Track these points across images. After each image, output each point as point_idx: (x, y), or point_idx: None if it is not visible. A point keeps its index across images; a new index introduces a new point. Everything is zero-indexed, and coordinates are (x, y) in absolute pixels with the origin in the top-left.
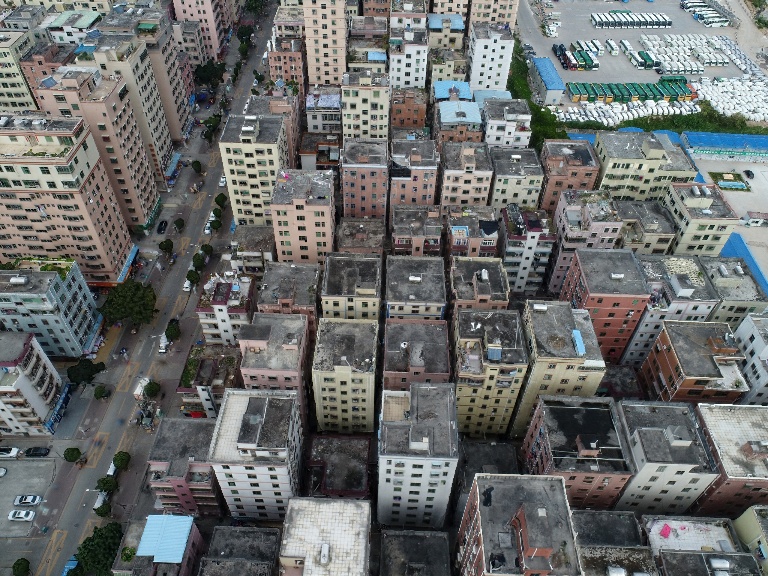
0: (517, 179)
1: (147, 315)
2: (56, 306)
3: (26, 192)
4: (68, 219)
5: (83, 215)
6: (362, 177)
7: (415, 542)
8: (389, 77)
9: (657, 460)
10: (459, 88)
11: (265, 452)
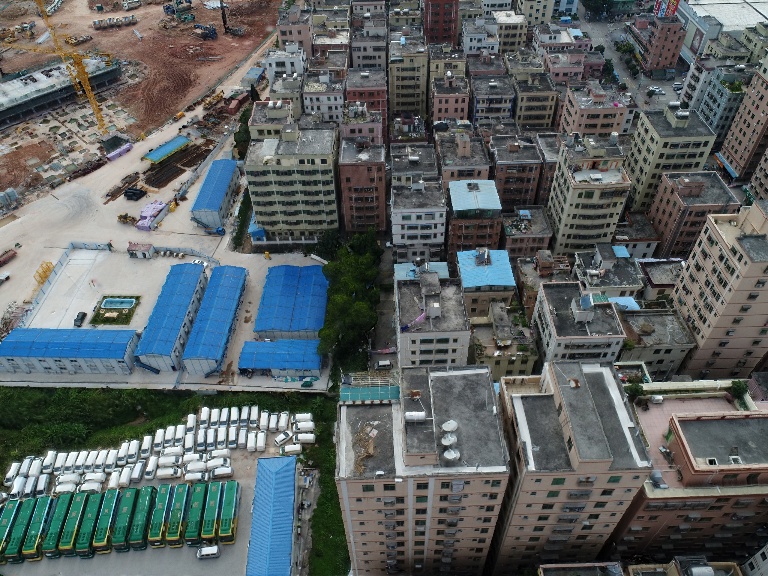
0: None
1: None
2: (711, 80)
3: None
4: None
5: None
6: None
7: None
8: (572, 179)
9: None
10: (477, 269)
11: None
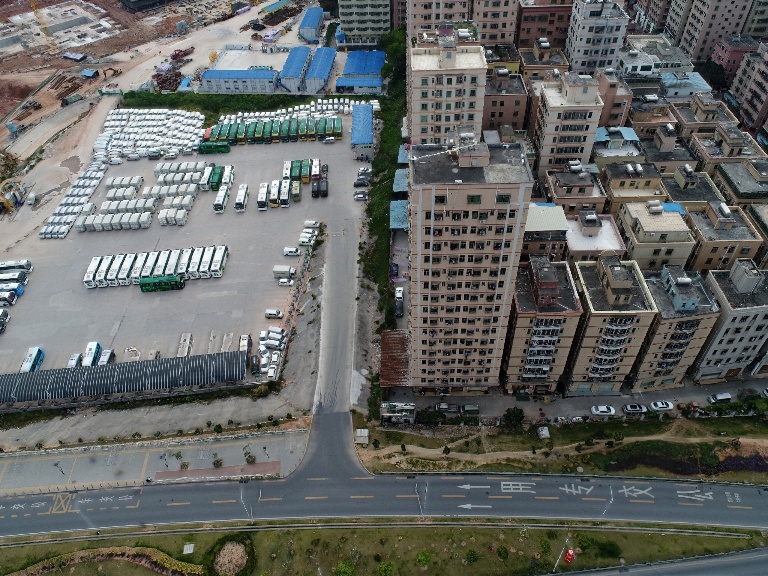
0: None
1: None
2: None
3: None
4: None
5: None
6: None
7: None
8: None
9: None
10: None
11: None
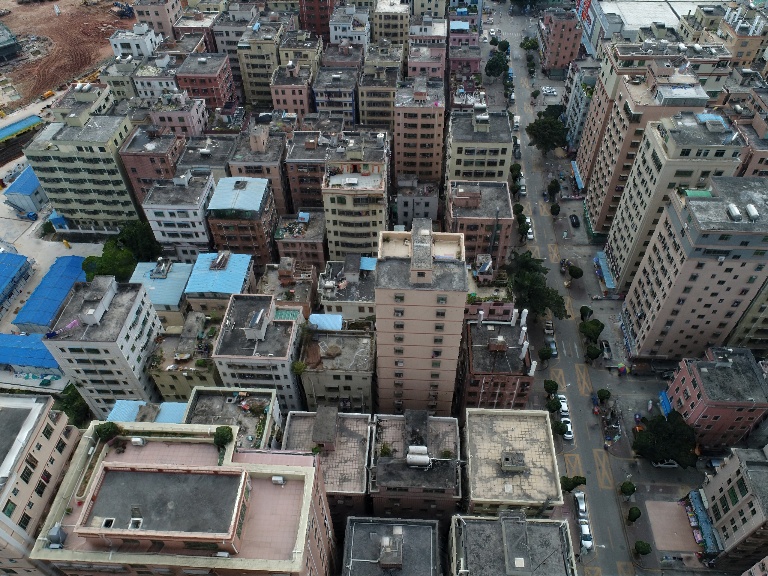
0: None
1: None
2: None
3: None
4: None
5: None
6: None
7: None
8: (323, 182)
9: (250, 4)
10: (207, 274)
11: None
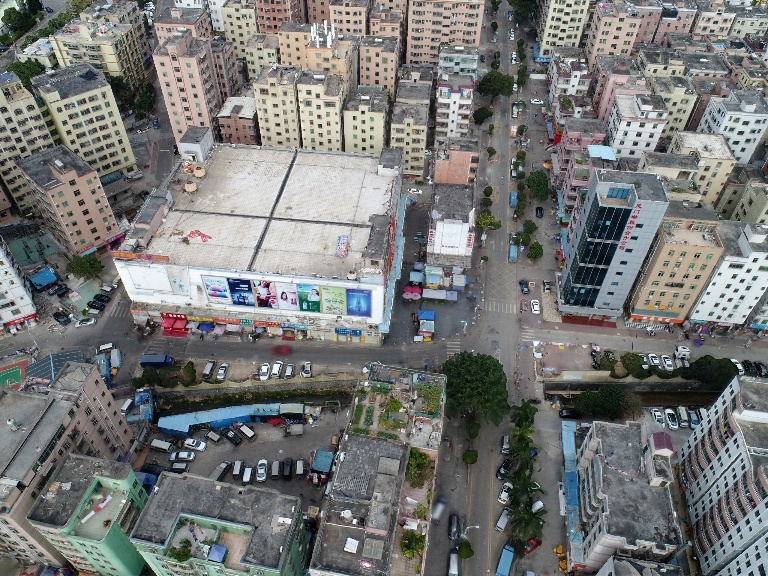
0: (751, 21)
1: (510, 90)
2: None
3: (451, 3)
4: (467, 25)
5: (478, 22)
6: (642, 17)
7: (739, 169)
8: None
9: None
10: None
11: (655, 114)
